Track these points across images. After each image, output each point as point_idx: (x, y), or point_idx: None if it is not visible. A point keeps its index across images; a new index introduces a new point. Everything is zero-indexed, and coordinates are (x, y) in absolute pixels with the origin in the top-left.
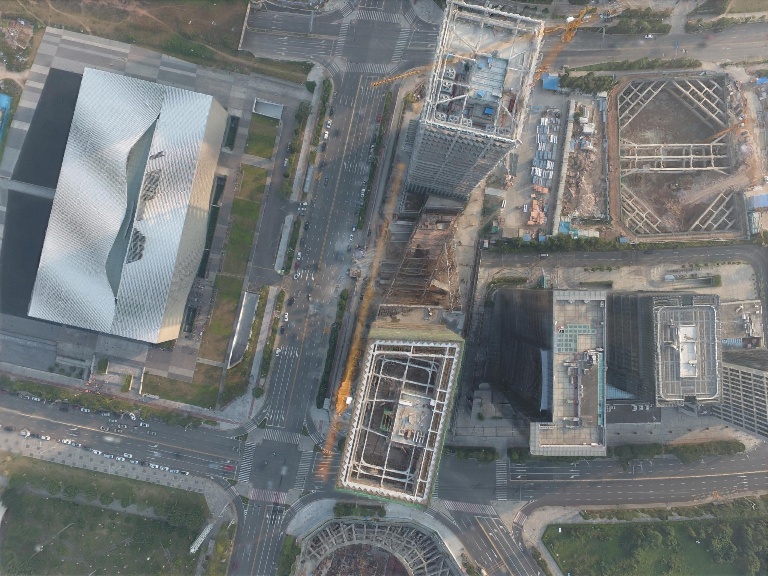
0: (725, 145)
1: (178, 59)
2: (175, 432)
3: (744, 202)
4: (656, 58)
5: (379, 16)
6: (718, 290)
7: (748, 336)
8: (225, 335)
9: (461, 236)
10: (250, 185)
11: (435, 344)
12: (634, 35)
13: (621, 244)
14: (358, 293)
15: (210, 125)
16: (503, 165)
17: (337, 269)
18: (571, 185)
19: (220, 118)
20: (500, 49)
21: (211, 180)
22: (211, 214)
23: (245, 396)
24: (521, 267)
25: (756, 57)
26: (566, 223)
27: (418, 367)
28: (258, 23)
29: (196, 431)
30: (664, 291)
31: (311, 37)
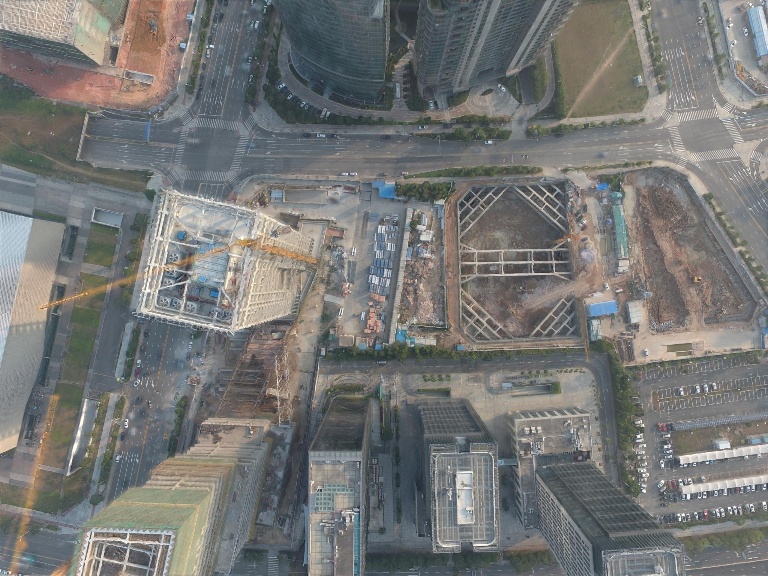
0: (566, 250)
1: (18, 169)
2: (18, 536)
3: (584, 309)
4: (494, 165)
5: (218, 124)
6: (557, 397)
7: (576, 450)
8: (65, 442)
9: (301, 342)
10: (90, 293)
11: (150, 531)
12: (473, 141)
13: (458, 352)
14: (197, 400)
15: (34, 245)
16: (341, 272)
17: (177, 376)
18: (409, 292)
19: (51, 233)
20: (233, 227)
21: (47, 291)
22: (54, 321)
23: (86, 501)
24: (360, 374)
25: (598, 162)
26: (403, 331)
27: (139, 550)
28: (99, 131)
29: (38, 535)
30: (472, 418)
31: (151, 145)
